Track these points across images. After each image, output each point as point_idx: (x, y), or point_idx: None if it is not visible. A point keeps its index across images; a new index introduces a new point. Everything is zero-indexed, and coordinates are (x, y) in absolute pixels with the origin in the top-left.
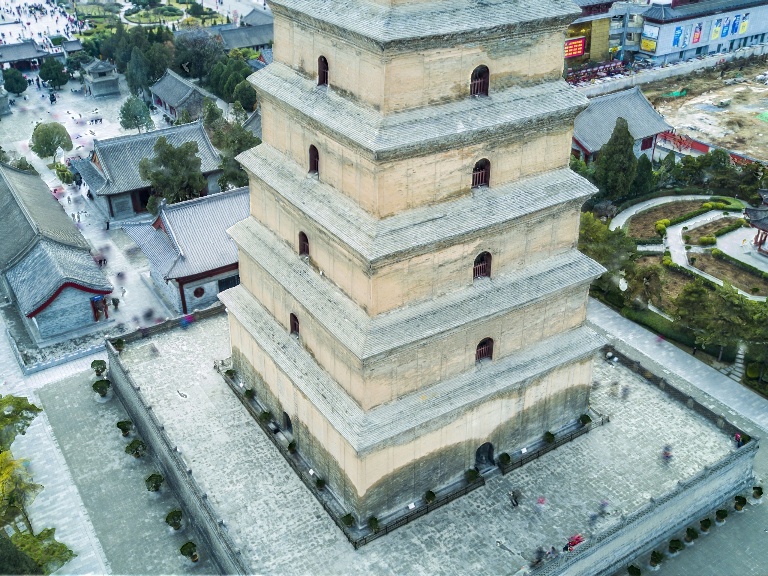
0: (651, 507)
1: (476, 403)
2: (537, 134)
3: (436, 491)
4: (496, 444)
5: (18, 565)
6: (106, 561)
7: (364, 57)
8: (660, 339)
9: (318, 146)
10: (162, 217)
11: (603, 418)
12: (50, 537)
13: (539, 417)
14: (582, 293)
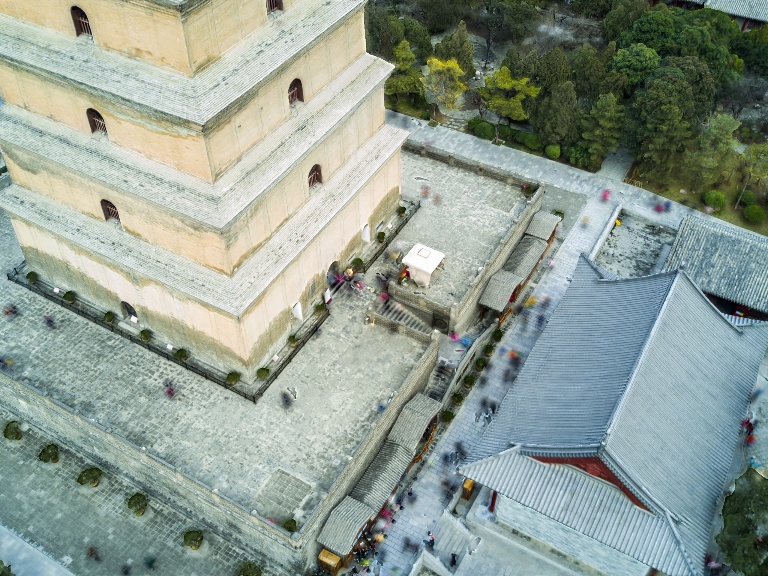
0: None
1: None
2: None
3: None
4: None
5: None
6: None
7: None
8: None
9: None
10: None
11: None
12: None
13: None
14: None
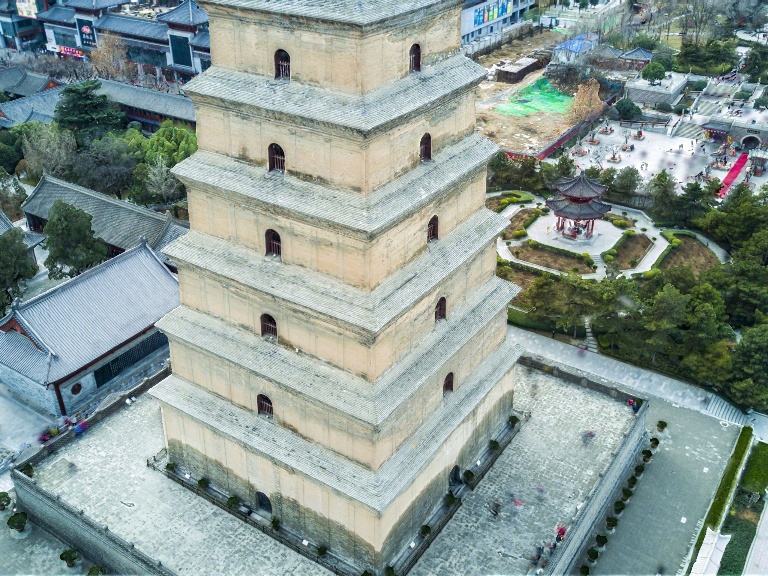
0: (601, 481)
1: (450, 434)
2: (466, 184)
3: (426, 524)
4: (461, 465)
5: None
6: None
7: (336, 144)
8: (522, 330)
9: (279, 230)
10: (17, 318)
11: (526, 415)
12: None
13: (485, 430)
14: (504, 312)
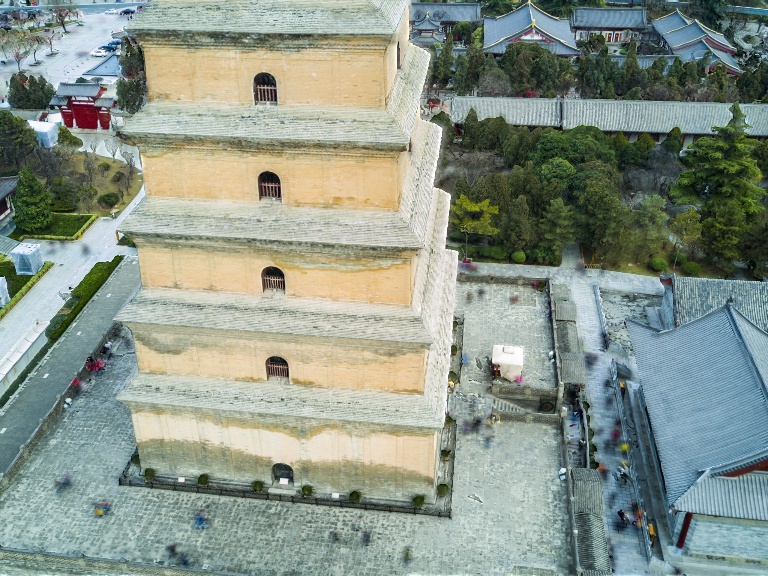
0: None
1: None
2: None
3: None
4: None
5: None
6: None
7: None
8: None
9: None
10: None
11: None
12: None
13: None
14: None
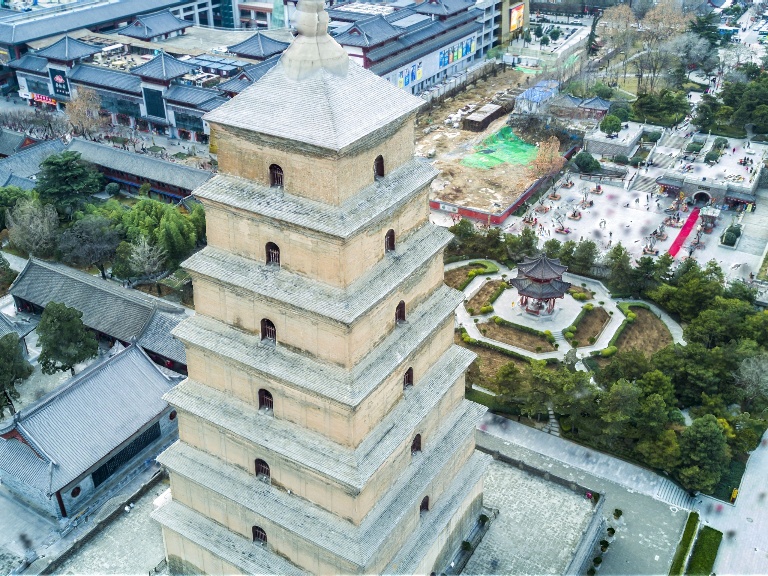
0: None
1: None
2: (436, 332)
3: None
4: (436, 571)
5: None
6: None
7: (322, 327)
8: (490, 414)
9: (272, 391)
10: (19, 430)
11: (494, 512)
12: None
13: (458, 534)
14: (473, 430)
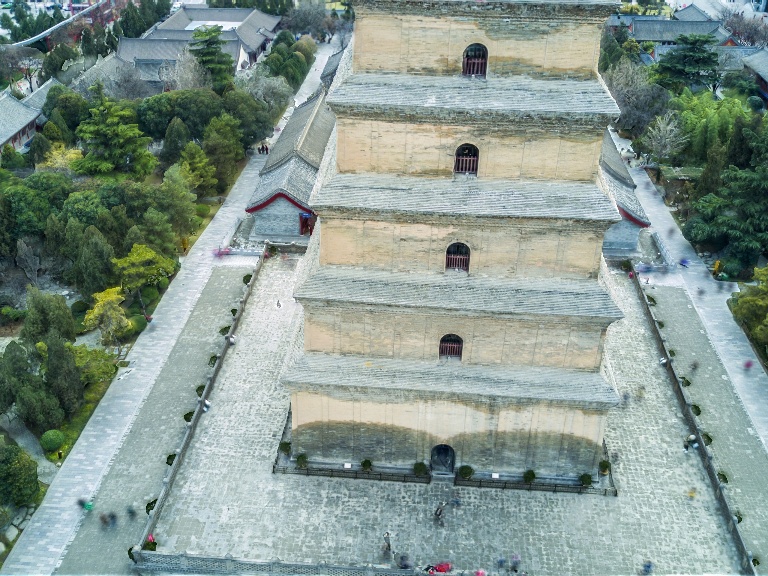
0: None
1: (429, 395)
2: (546, 134)
3: (380, 465)
4: (459, 452)
5: (61, 361)
6: (145, 399)
7: None
8: None
9: None
10: None
11: (610, 489)
12: (109, 359)
13: (521, 449)
14: (595, 333)
